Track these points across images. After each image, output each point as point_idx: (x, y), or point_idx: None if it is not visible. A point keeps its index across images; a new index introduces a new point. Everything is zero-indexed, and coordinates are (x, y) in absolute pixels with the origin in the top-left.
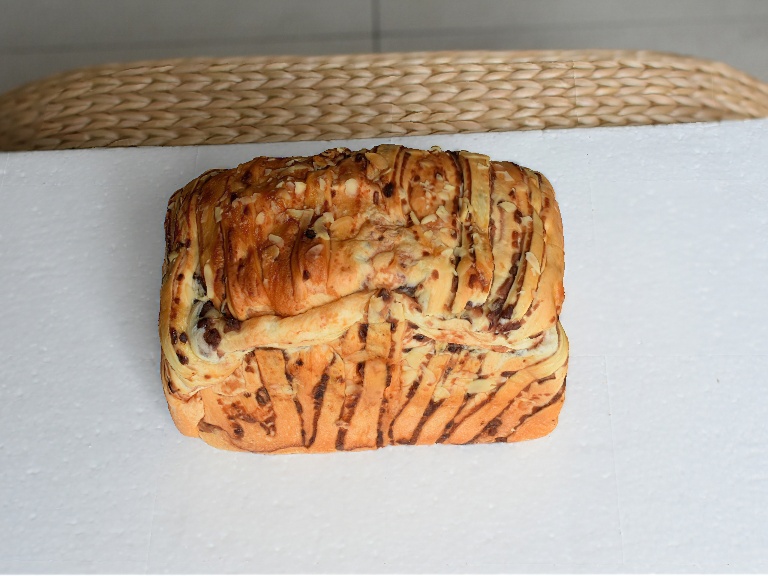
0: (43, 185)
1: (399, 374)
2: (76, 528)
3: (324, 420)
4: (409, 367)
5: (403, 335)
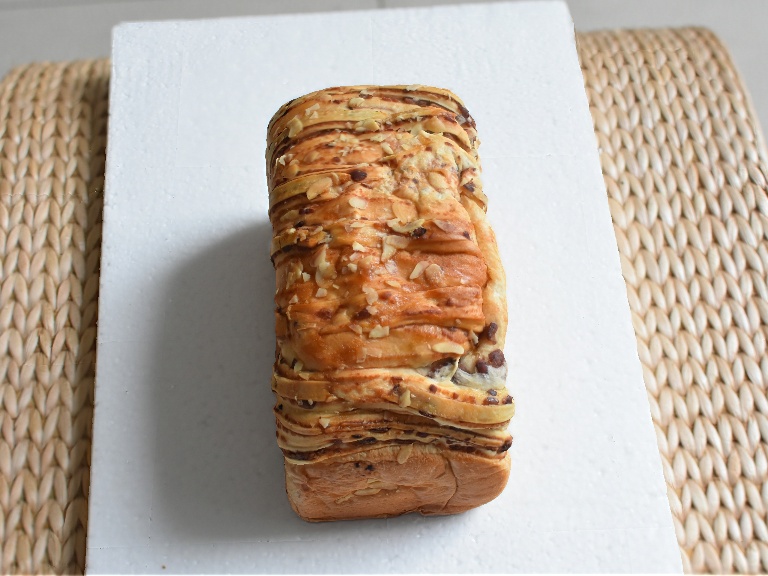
0: None
1: None
2: None
3: None
4: None
5: None
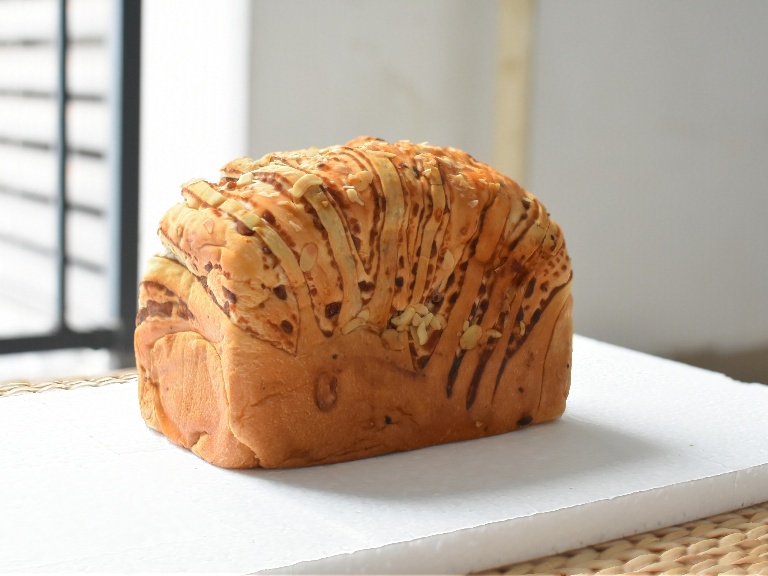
0: None
1: None
2: None
3: None
4: None
5: None
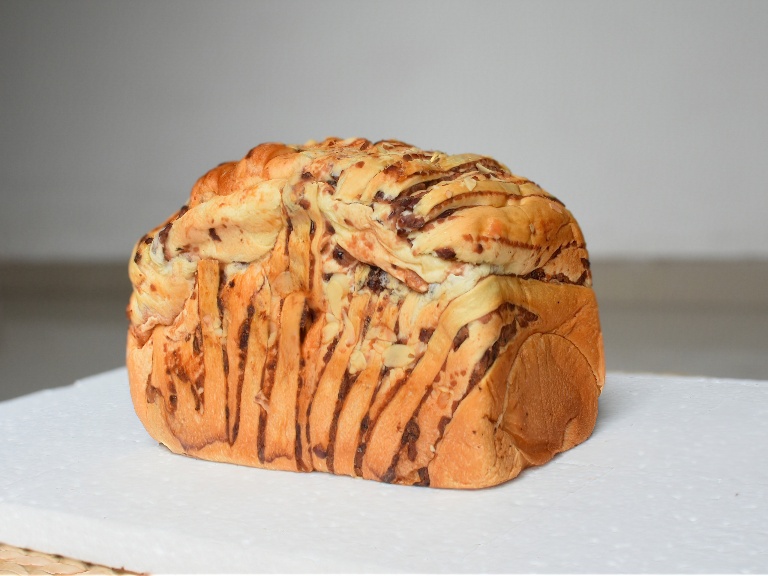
0: None
1: (322, 326)
2: None
3: (247, 391)
4: (332, 315)
5: (320, 242)
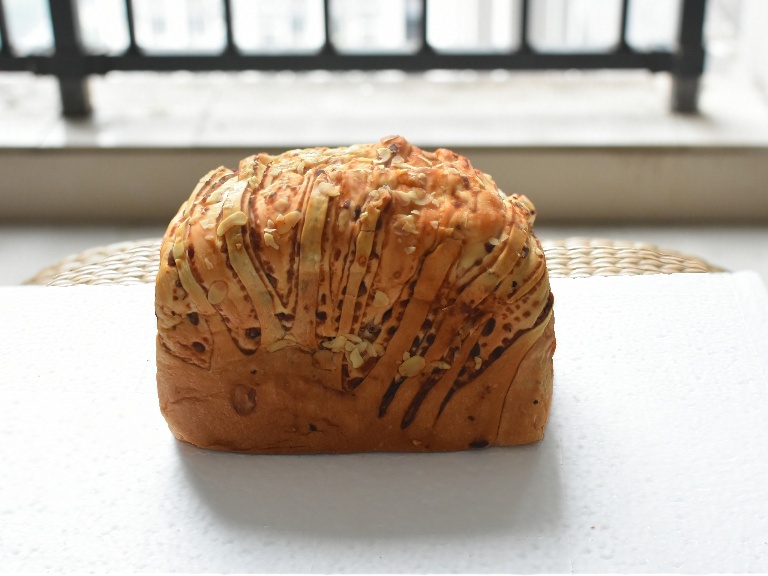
0: (766, 540)
1: None
2: None
3: None
4: None
5: None
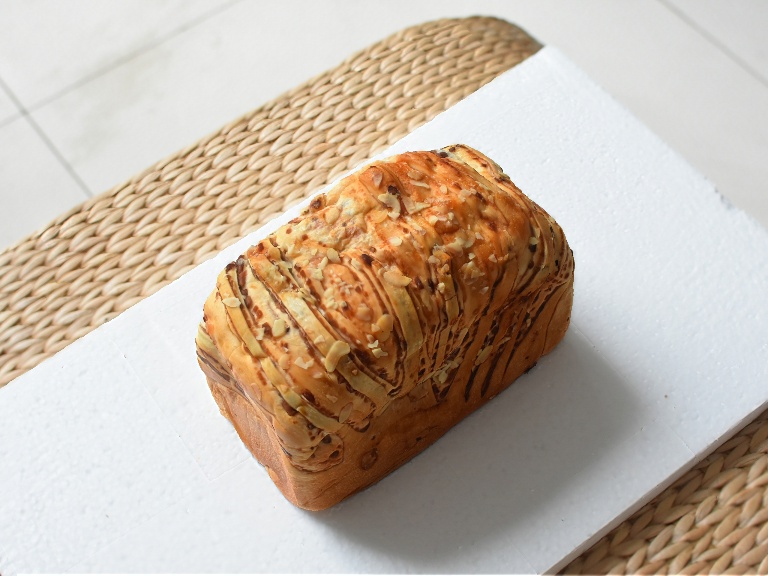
0: None
1: None
2: (485, 150)
3: None
4: None
5: None
